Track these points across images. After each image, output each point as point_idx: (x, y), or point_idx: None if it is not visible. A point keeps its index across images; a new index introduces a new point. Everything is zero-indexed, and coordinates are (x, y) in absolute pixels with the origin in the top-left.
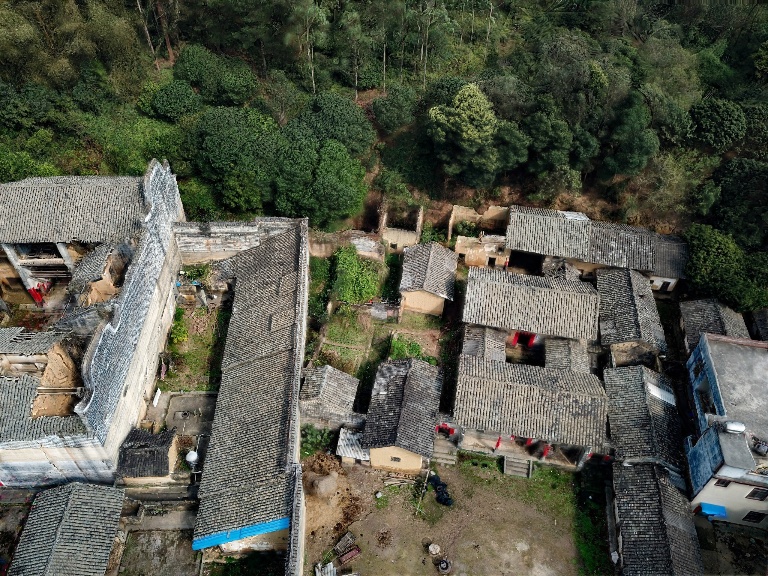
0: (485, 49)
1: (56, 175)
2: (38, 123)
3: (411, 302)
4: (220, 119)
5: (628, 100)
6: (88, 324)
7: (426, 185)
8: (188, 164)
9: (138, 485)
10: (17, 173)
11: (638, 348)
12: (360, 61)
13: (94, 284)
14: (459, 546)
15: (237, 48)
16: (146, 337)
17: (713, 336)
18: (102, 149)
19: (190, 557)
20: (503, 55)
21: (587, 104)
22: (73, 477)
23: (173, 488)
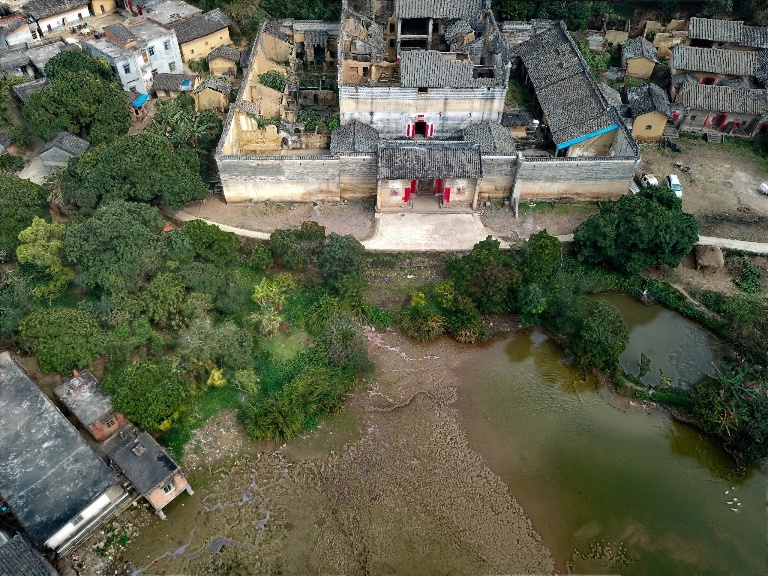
0: None
1: None
2: None
3: (631, 69)
4: None
5: None
6: None
7: (623, 13)
8: None
9: None
10: None
11: None
12: None
13: (466, 36)
14: (691, 165)
15: None
16: None
17: None
18: None
19: None
20: None
21: None
22: None
23: None
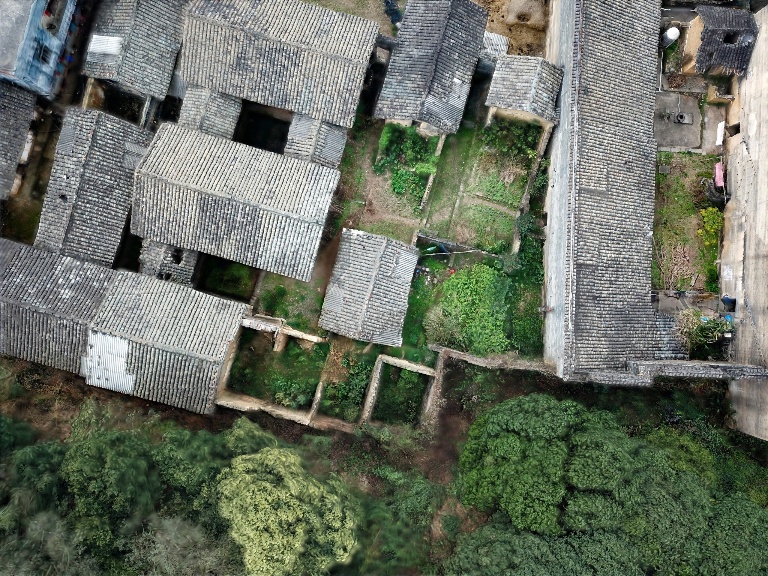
0: None
1: None
2: None
3: None
4: None
5: None
6: None
7: None
8: None
9: None
10: None
11: None
12: None
13: None
14: None
15: None
16: (767, 171)
17: (4, 68)
18: None
19: None
20: None
21: None
22: None
23: None
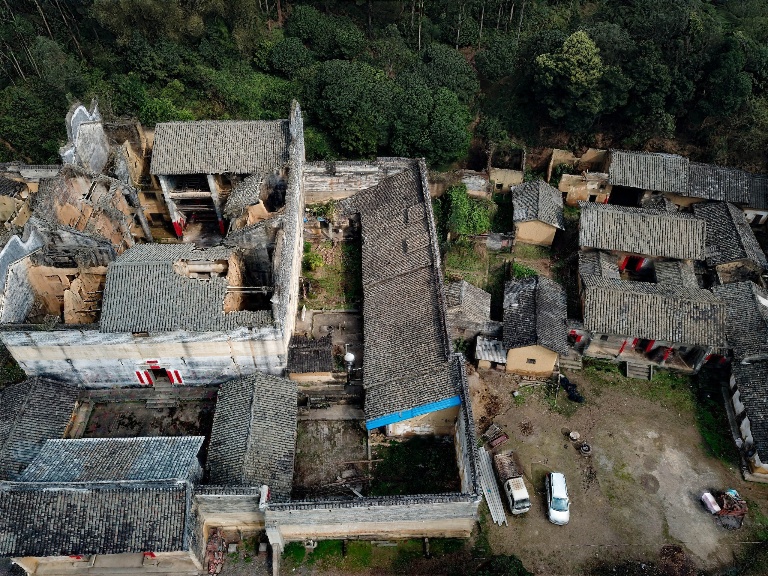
0: (569, 10)
1: (194, 120)
2: (169, 75)
3: (523, 233)
4: (337, 70)
5: (724, 45)
6: (253, 240)
7: (523, 133)
8: (305, 113)
9: (300, 383)
10: (163, 116)
11: (742, 268)
12: (464, 17)
13: (251, 208)
14: (595, 434)
15: (340, 10)
16: (295, 257)
17: None
18: (225, 100)
19: (357, 441)
20: (584, 17)
21: (685, 50)
22: (246, 374)
23: (331, 386)
